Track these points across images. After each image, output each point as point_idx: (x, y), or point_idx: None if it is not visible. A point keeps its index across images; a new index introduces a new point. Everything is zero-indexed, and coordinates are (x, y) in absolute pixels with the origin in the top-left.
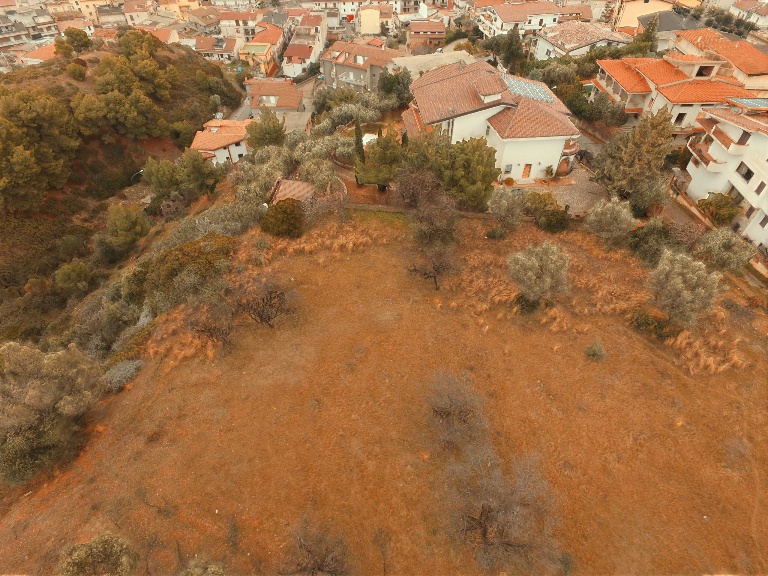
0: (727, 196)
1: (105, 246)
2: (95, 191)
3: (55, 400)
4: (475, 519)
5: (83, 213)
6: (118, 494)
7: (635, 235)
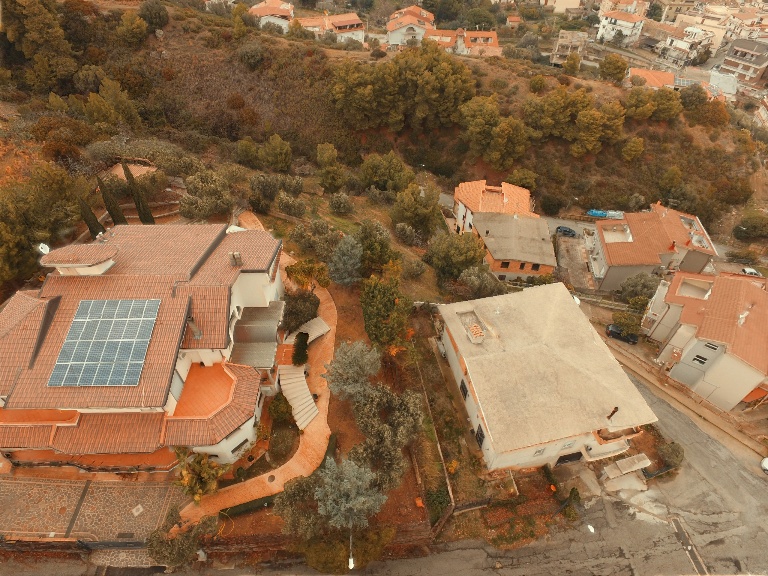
0: None
1: None
2: (409, 154)
3: None
4: None
5: None
6: None
7: None
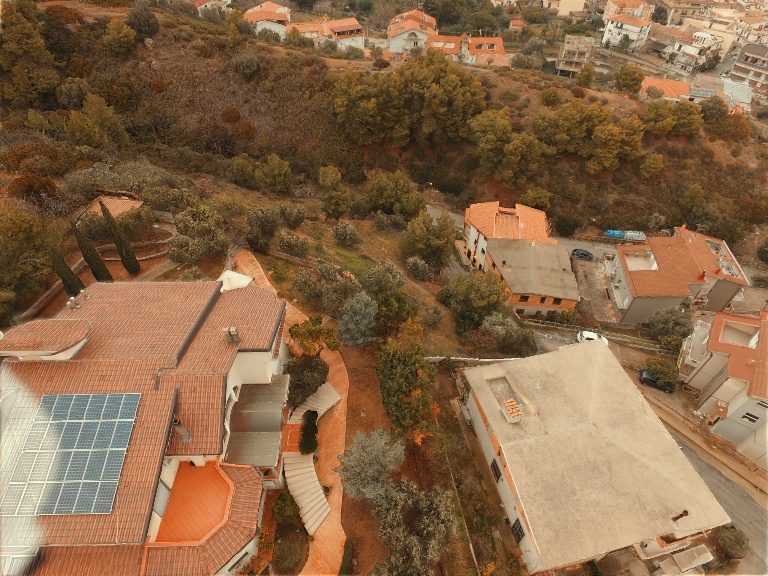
0: None
1: None
2: (415, 170)
3: None
4: None
5: (387, 173)
6: None
7: None
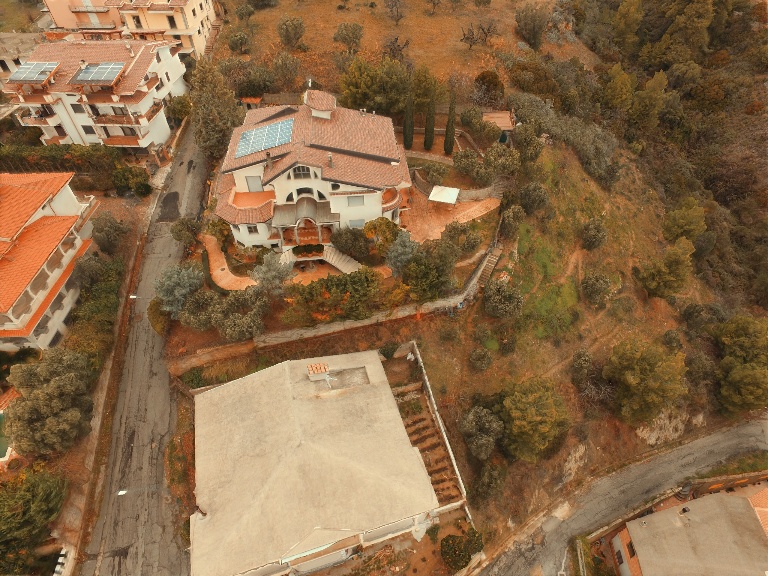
0: (177, 97)
1: (698, 236)
2: None
3: (523, 11)
4: (395, 5)
5: None
6: None
7: None
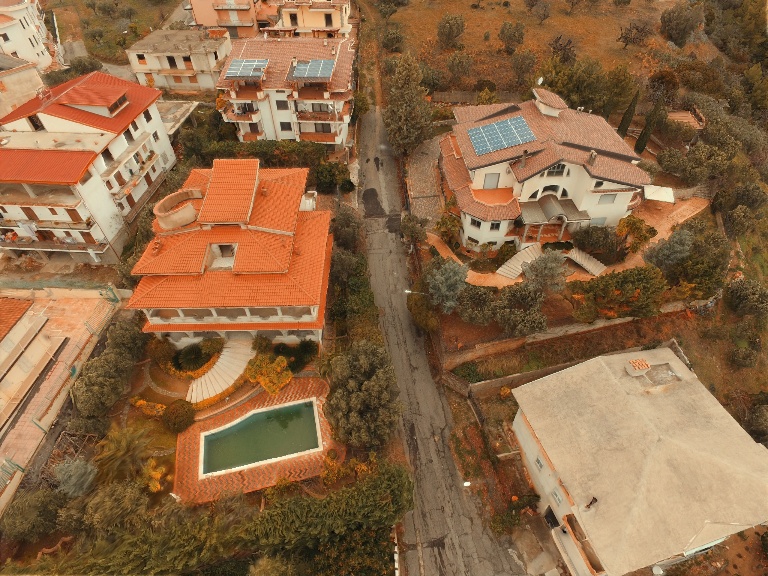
0: (357, 94)
1: None
2: None
3: (673, 10)
4: (535, 4)
5: None
6: (636, 22)
7: (434, 85)
